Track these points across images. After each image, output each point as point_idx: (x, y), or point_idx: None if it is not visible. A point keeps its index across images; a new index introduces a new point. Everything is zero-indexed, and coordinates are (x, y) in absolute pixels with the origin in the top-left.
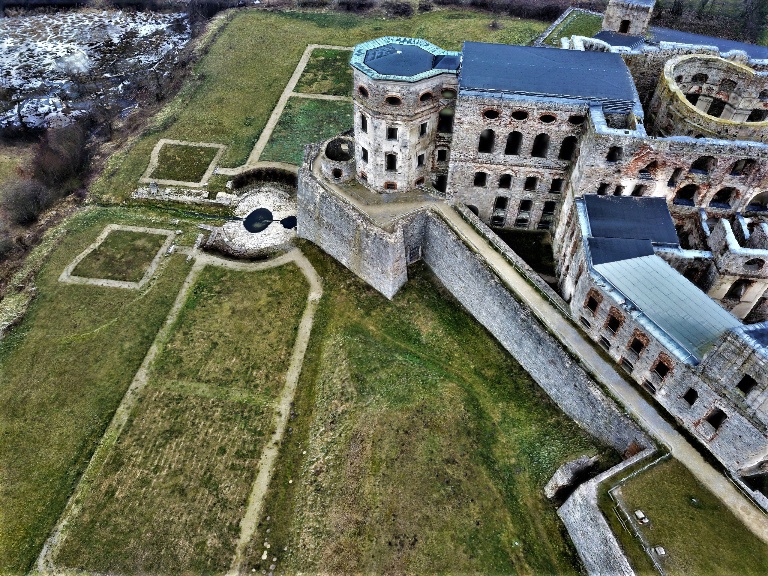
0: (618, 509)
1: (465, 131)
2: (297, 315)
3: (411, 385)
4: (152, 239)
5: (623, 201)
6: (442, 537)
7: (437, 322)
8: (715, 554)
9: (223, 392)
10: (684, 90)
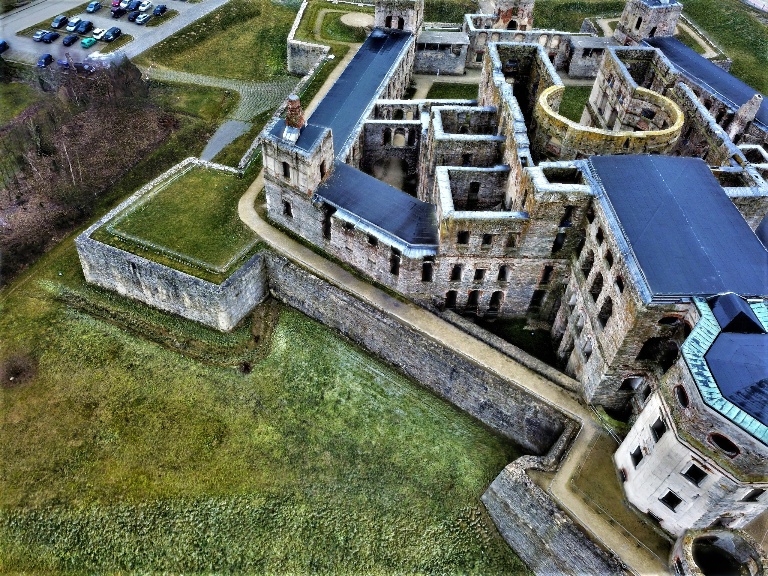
0: None
1: None
2: None
3: None
4: None
5: None
6: None
7: None
8: None
9: None
10: None
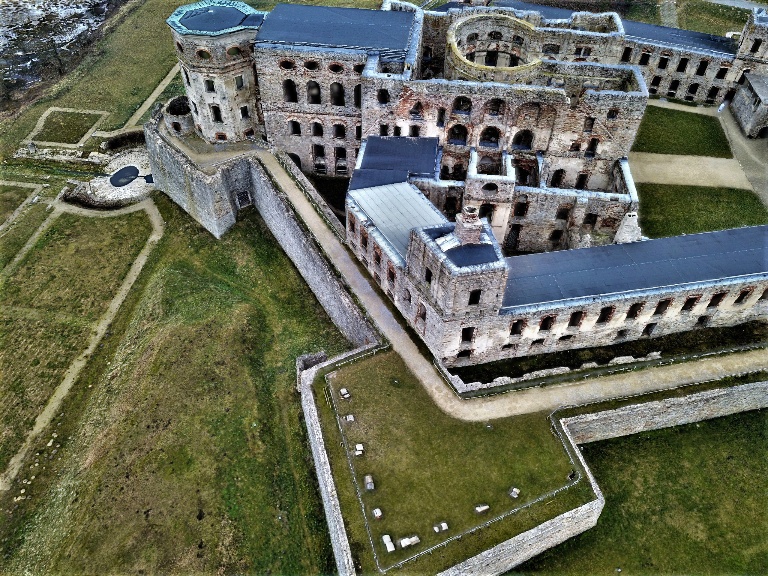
0: (328, 388)
1: (268, 81)
2: (134, 253)
3: (210, 306)
4: (20, 191)
5: (400, 141)
6: (192, 420)
7: (251, 256)
8: (397, 421)
9: (50, 316)
10: (483, 47)
